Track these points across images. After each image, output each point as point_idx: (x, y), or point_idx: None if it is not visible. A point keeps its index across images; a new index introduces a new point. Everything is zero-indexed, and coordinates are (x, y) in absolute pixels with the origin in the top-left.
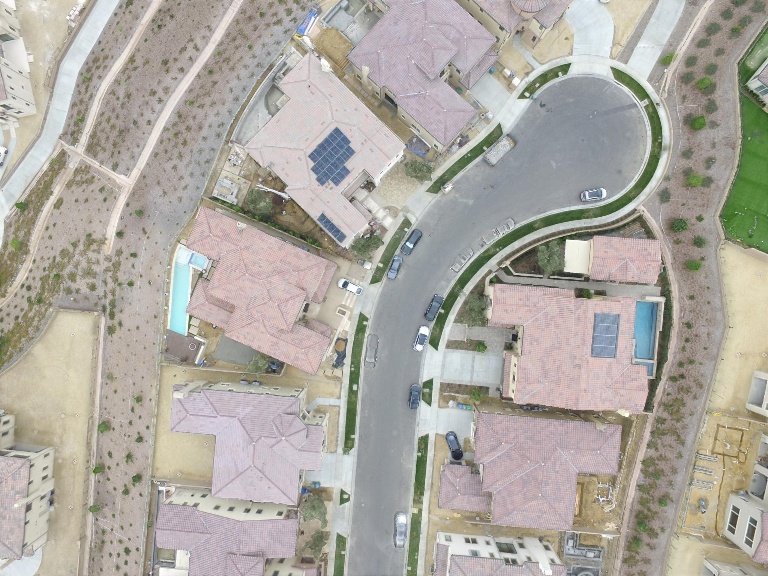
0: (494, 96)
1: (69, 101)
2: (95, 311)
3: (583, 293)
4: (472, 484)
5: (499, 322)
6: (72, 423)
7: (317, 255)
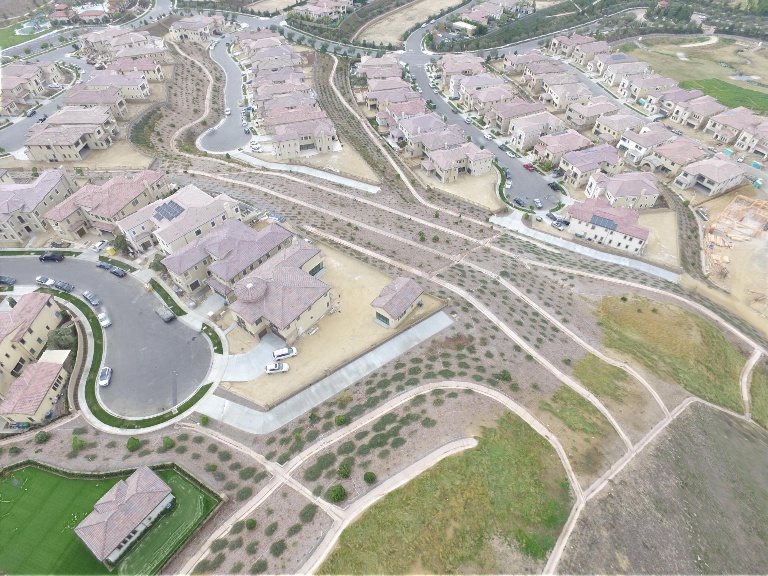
0: (208, 308)
1: (283, 169)
2: (149, 169)
3: None
4: None
5: (21, 298)
6: (91, 165)
7: None
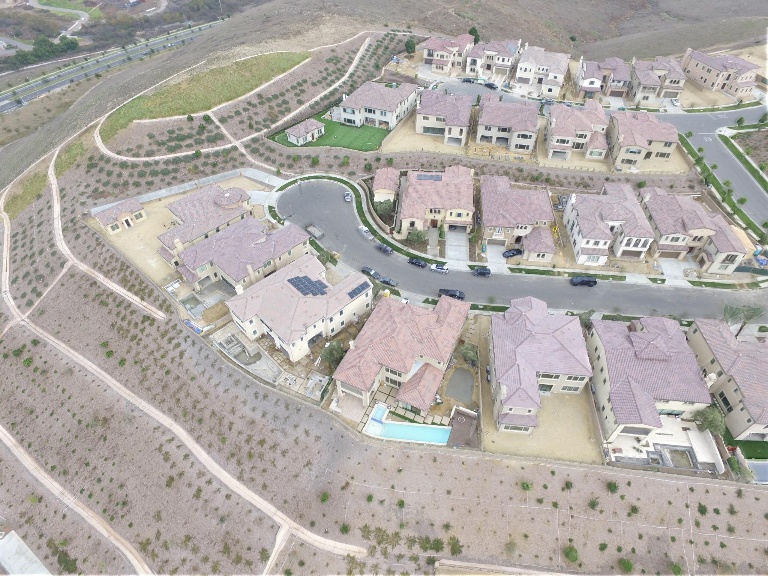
0: None
1: None
2: (434, 575)
3: None
4: (534, 236)
5: (424, 217)
6: None
7: None
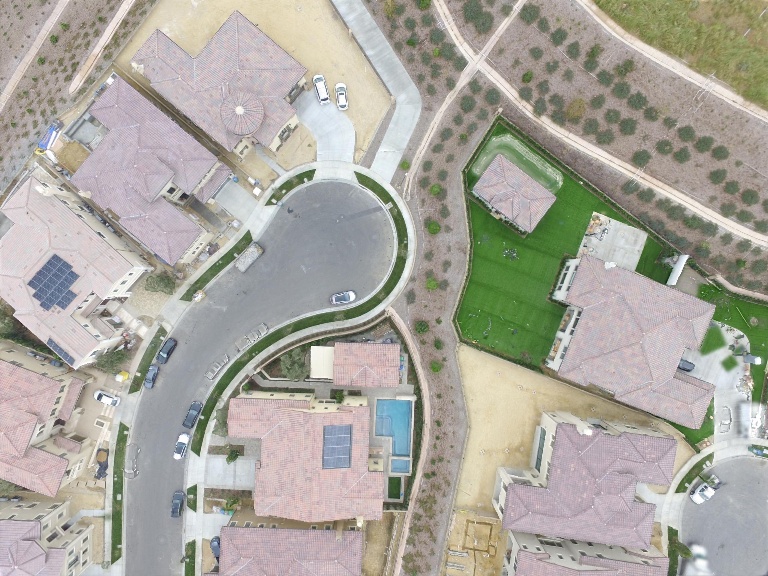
0: (241, 204)
1: None
2: None
3: (335, 395)
4: None
5: (236, 436)
6: None
7: (68, 370)
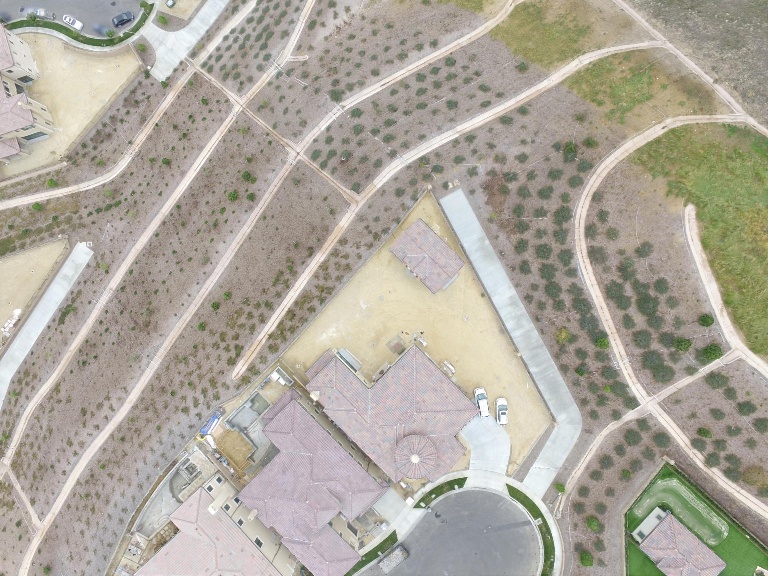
0: (390, 504)
1: (0, 407)
2: None
3: None
4: None
5: None
6: None
7: None
